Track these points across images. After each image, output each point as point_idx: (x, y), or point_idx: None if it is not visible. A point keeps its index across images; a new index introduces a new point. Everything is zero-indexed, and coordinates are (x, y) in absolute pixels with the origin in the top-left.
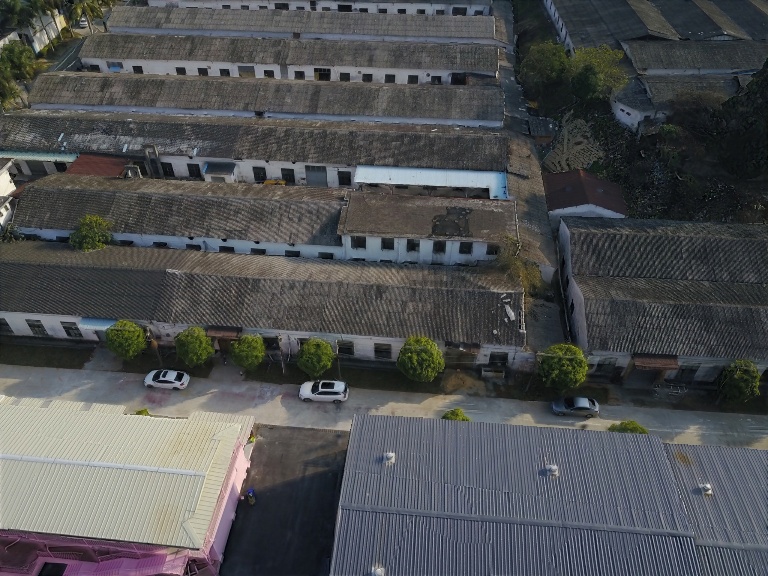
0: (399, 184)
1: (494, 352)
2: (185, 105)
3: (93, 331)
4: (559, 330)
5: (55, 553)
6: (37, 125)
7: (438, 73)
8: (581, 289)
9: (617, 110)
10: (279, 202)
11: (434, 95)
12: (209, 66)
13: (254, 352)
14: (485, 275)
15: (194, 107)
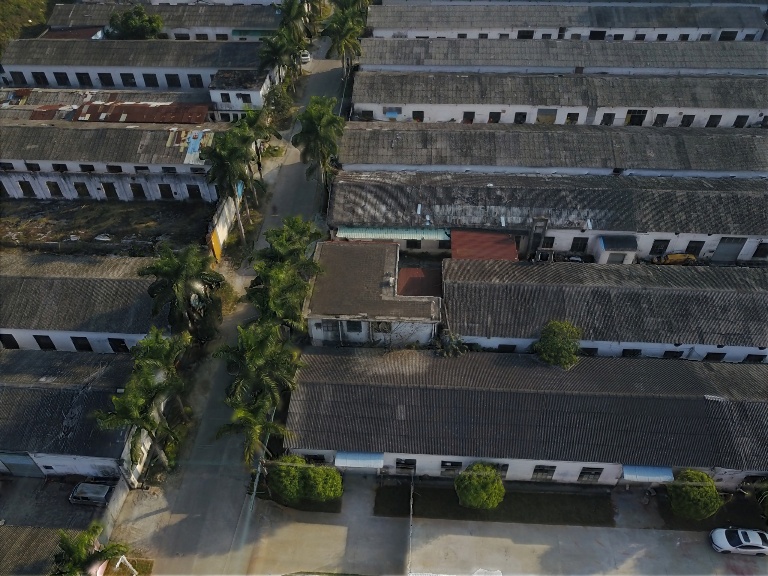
0: None
1: None
2: (531, 163)
3: (618, 476)
4: None
5: None
6: (384, 195)
7: None
8: None
9: None
10: None
11: None
12: (504, 110)
13: None
14: None
15: (542, 165)
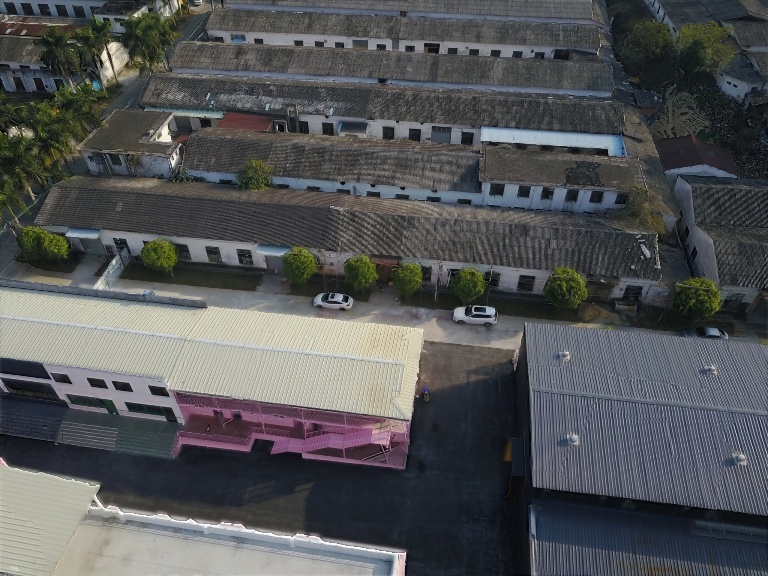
0: (523, 143)
1: (630, 286)
2: (314, 72)
3: (264, 259)
4: (686, 271)
5: (268, 429)
6: (186, 85)
7: (542, 49)
8: (708, 234)
9: (723, 83)
10: (421, 154)
11: (546, 67)
12: (326, 40)
13: (416, 277)
14: (616, 221)
15: (322, 74)
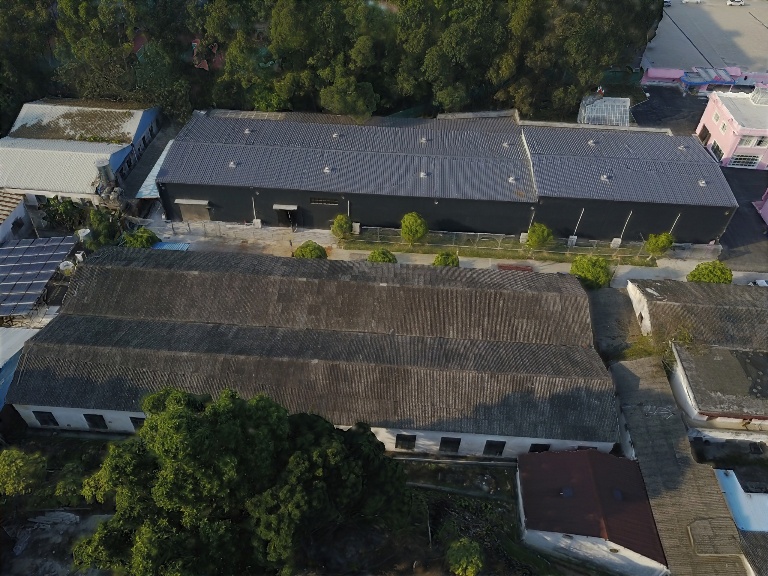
0: None
1: None
2: None
3: None
4: (593, 315)
5: None
6: None
7: None
8: None
9: None
10: None
11: None
12: None
13: None
14: None
15: None
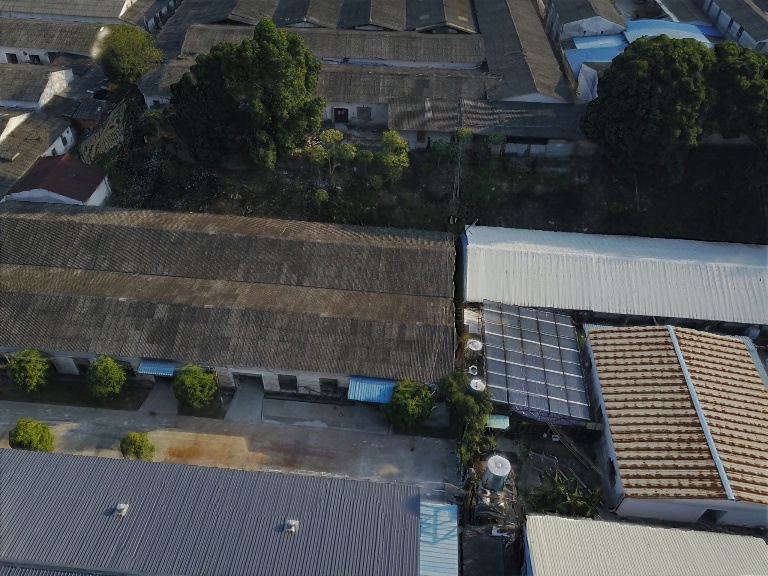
0: None
1: None
2: None
3: None
4: None
5: None
6: None
7: (34, 52)
8: None
9: None
10: None
11: None
12: None
13: None
14: None
15: None
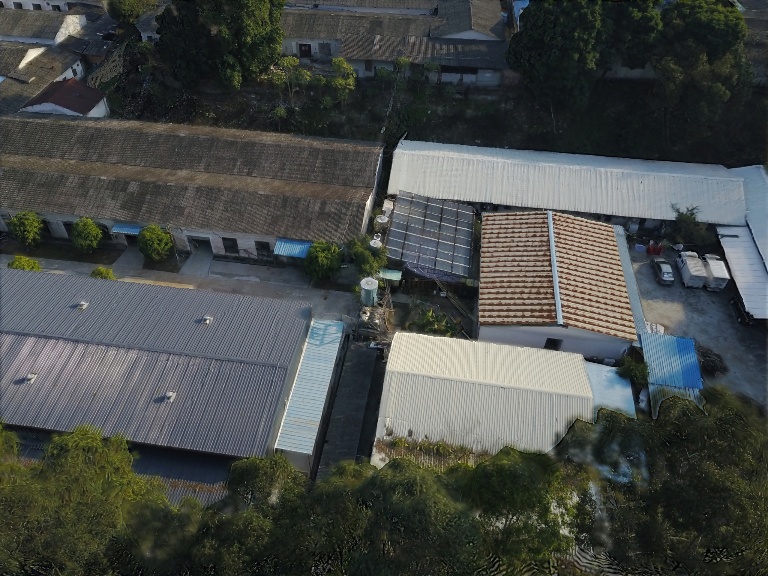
0: None
1: None
2: None
3: None
4: None
5: None
6: None
7: (55, 2)
8: None
9: None
10: None
11: (7, 16)
12: None
13: None
14: None
15: None
